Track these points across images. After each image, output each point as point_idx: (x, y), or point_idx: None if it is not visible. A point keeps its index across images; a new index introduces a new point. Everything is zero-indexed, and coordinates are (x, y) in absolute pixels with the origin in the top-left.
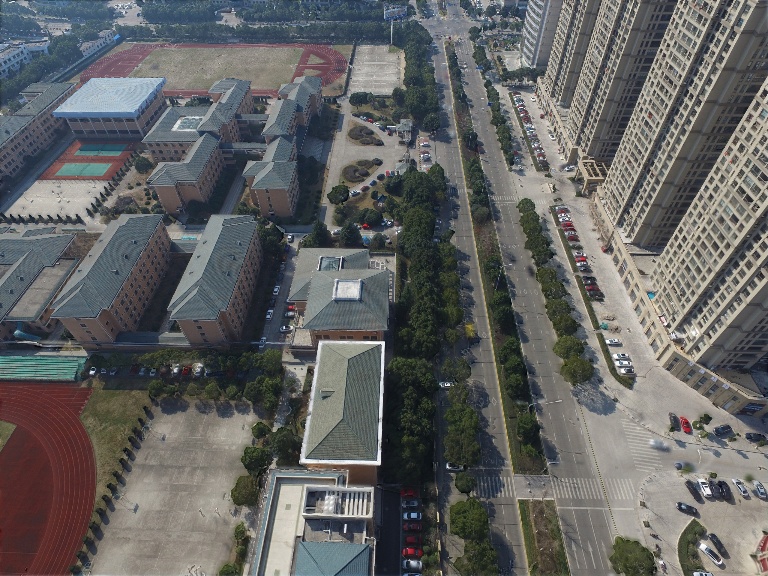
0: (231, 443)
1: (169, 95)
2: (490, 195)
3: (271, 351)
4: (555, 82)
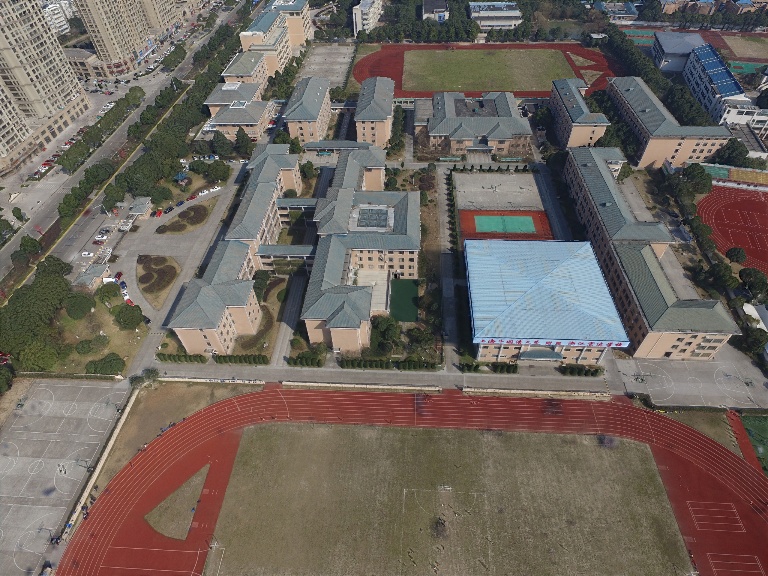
0: None
1: (496, 400)
2: None
3: None
4: None
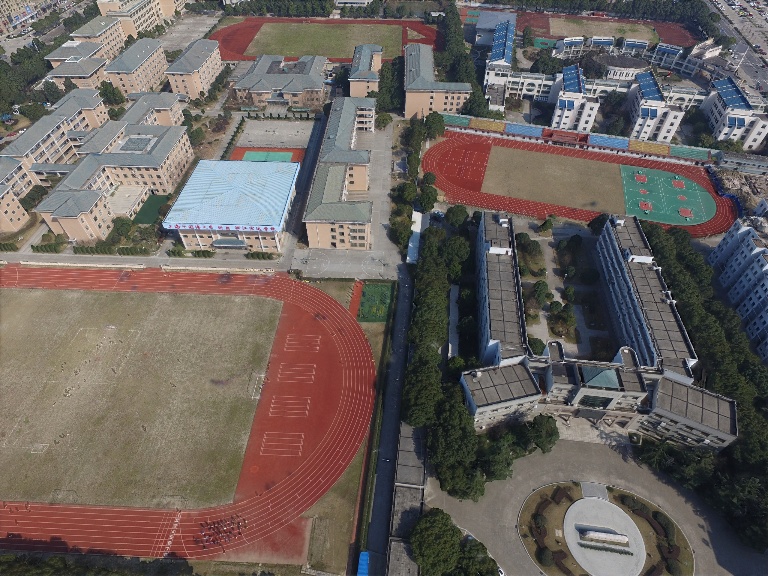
0: None
1: (184, 274)
2: None
3: None
4: None
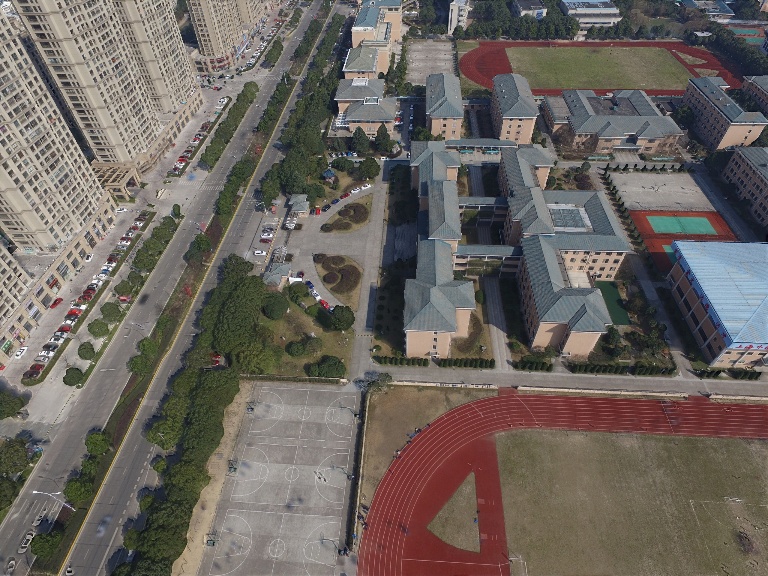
0: (415, 84)
1: (749, 407)
2: None
3: (403, 90)
4: None
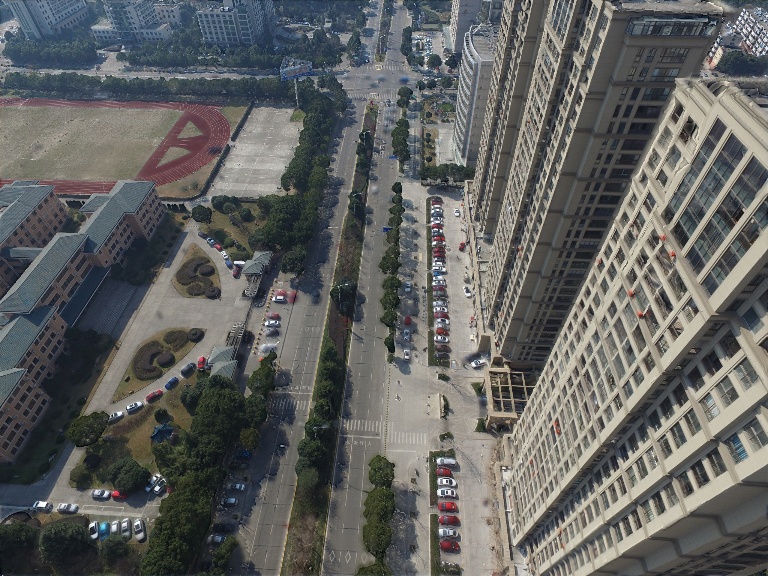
0: None
1: None
2: (344, 418)
3: None
4: (479, 203)
